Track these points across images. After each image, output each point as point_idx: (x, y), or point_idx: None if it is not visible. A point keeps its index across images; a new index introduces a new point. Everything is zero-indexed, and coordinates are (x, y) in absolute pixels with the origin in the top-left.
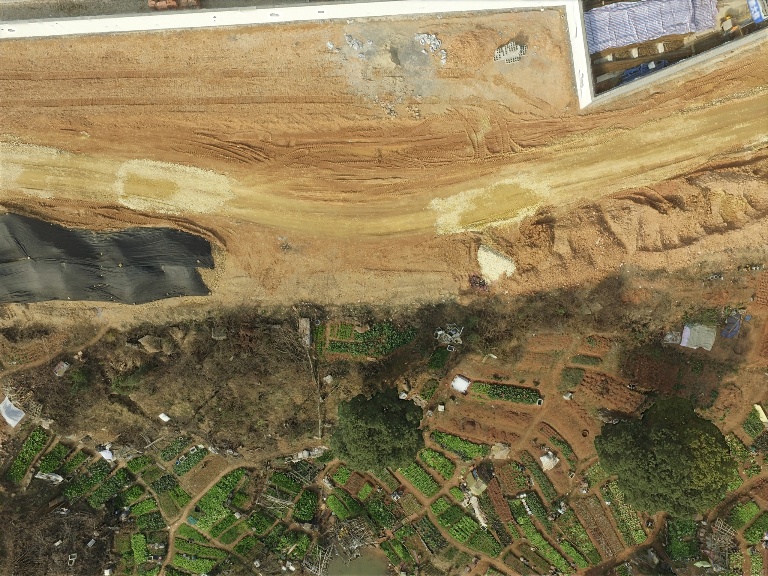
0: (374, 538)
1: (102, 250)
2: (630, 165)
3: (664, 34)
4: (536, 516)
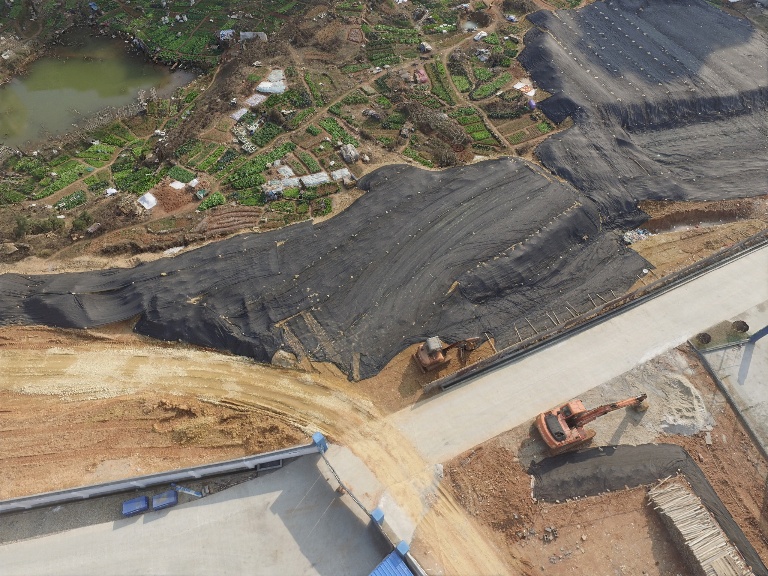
0: None
1: (16, 310)
2: None
3: None
4: None
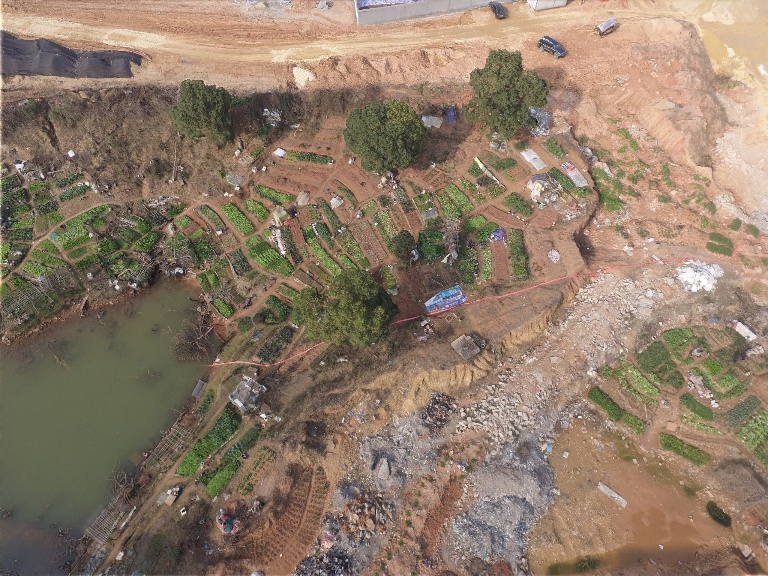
0: (194, 270)
1: None
2: (384, 44)
3: (399, 3)
4: (322, 237)
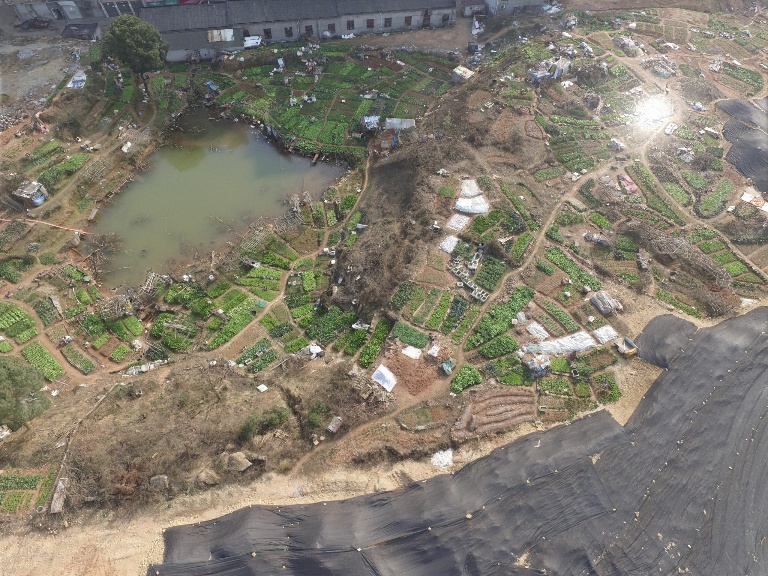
0: None
1: (283, 573)
2: None
3: None
4: None
